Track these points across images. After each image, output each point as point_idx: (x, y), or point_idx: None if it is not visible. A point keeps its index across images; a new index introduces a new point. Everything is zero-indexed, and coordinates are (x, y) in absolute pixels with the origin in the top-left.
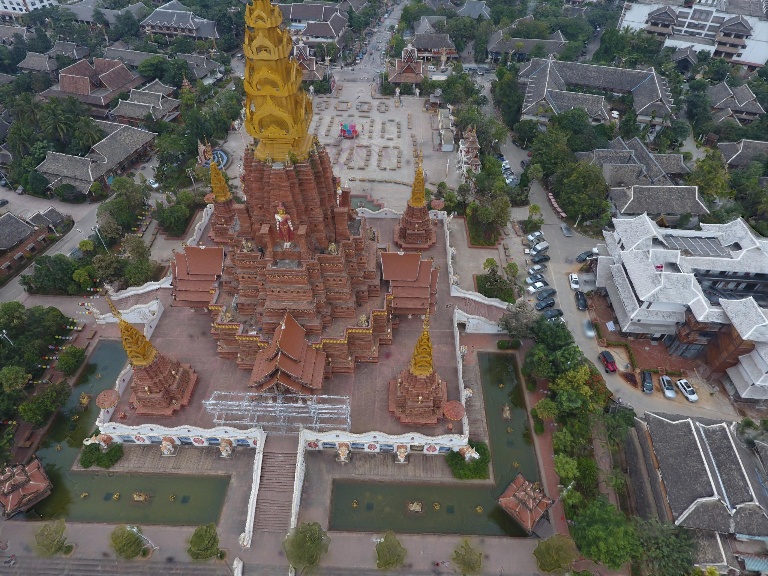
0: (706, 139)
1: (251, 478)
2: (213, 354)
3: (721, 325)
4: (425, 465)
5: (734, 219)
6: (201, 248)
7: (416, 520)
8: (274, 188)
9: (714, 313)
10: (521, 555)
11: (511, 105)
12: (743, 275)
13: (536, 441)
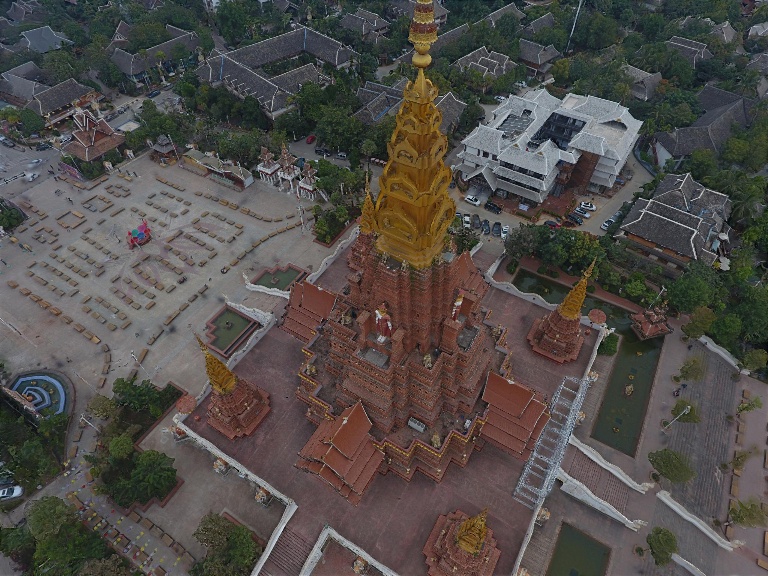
0: (380, 60)
1: (572, 504)
2: (431, 489)
3: (580, 158)
4: (598, 369)
5: (478, 100)
6: (345, 423)
7: (637, 396)
8: (453, 279)
9: (575, 154)
10: (675, 348)
11: (252, 111)
12: (541, 126)
13: (598, 297)
